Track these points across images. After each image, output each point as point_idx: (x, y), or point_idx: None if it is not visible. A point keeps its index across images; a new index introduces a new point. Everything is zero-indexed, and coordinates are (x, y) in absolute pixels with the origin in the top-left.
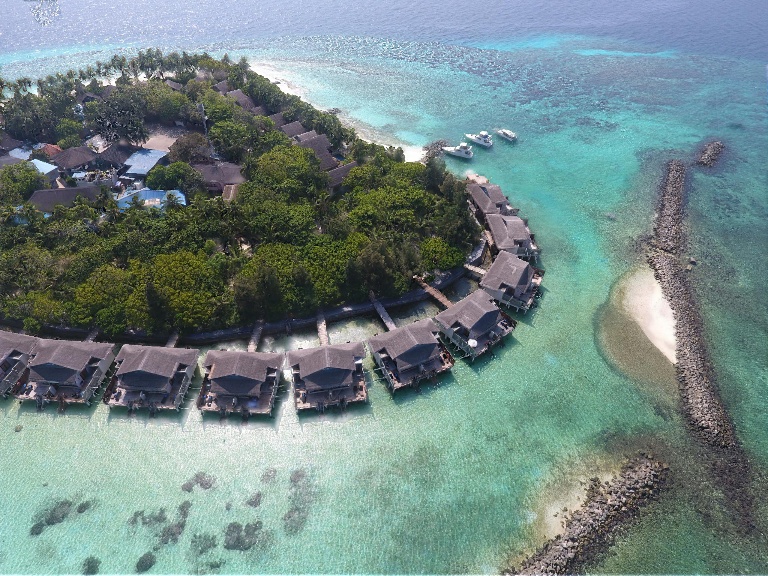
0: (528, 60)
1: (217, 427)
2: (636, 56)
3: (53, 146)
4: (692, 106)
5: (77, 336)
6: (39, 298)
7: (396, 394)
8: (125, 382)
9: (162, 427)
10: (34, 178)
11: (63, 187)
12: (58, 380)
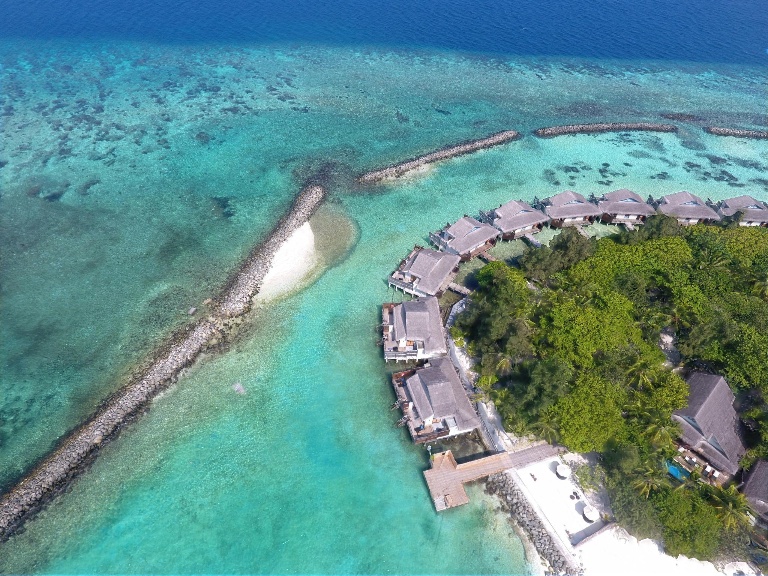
0: None
1: None
2: None
3: None
4: None
5: None
6: None
7: None
8: None
9: None
10: None
11: None
12: None
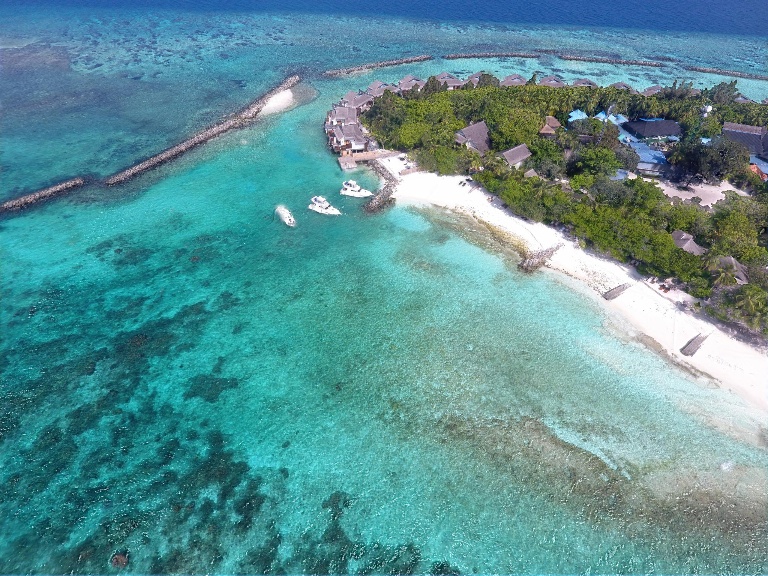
0: None
1: None
2: None
3: (751, 167)
4: None
5: None
6: None
7: None
8: None
9: None
10: (688, 123)
11: None
12: None
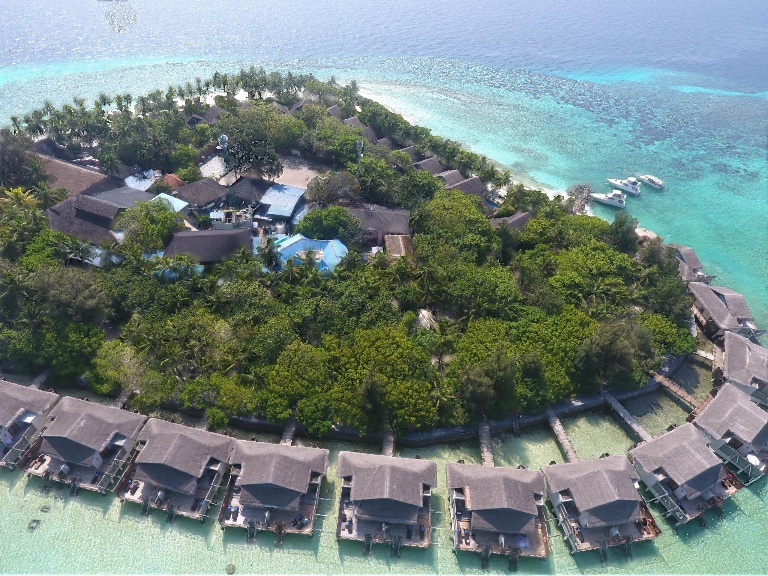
0: (630, 95)
1: (479, 573)
2: (737, 96)
3: (173, 176)
4: None
5: (265, 430)
6: (225, 383)
7: (678, 527)
8: (363, 510)
9: (411, 571)
10: (173, 219)
11: (190, 225)
12: (277, 504)
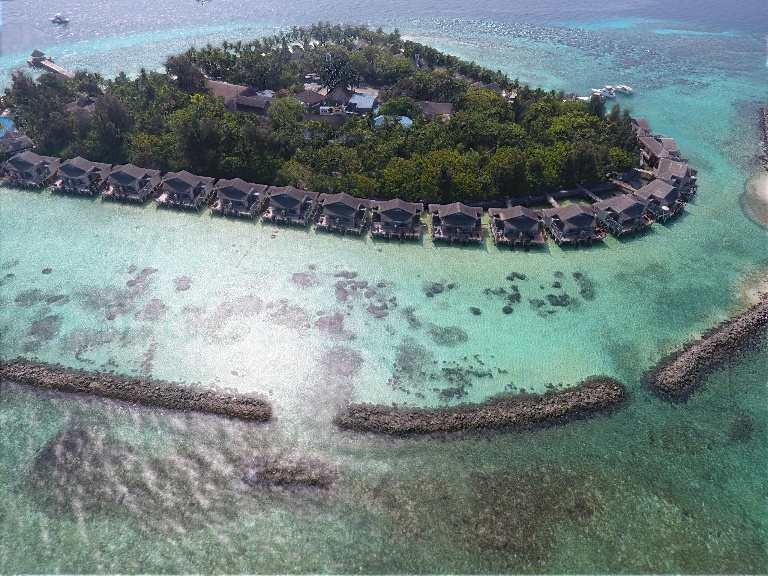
0: (615, 37)
1: (509, 252)
2: (705, 35)
3: None
4: (765, 72)
5: None
6: (360, 176)
7: (619, 238)
8: (447, 222)
9: (473, 251)
10: (301, 107)
11: None
12: (401, 220)
